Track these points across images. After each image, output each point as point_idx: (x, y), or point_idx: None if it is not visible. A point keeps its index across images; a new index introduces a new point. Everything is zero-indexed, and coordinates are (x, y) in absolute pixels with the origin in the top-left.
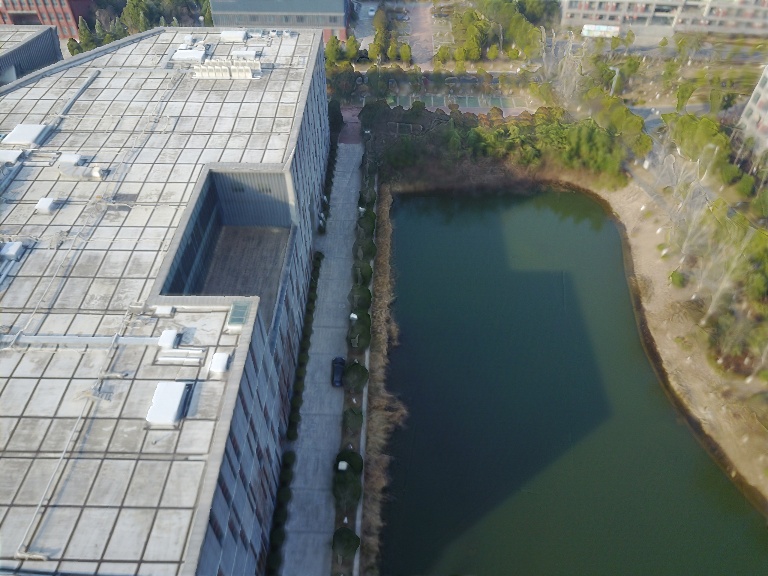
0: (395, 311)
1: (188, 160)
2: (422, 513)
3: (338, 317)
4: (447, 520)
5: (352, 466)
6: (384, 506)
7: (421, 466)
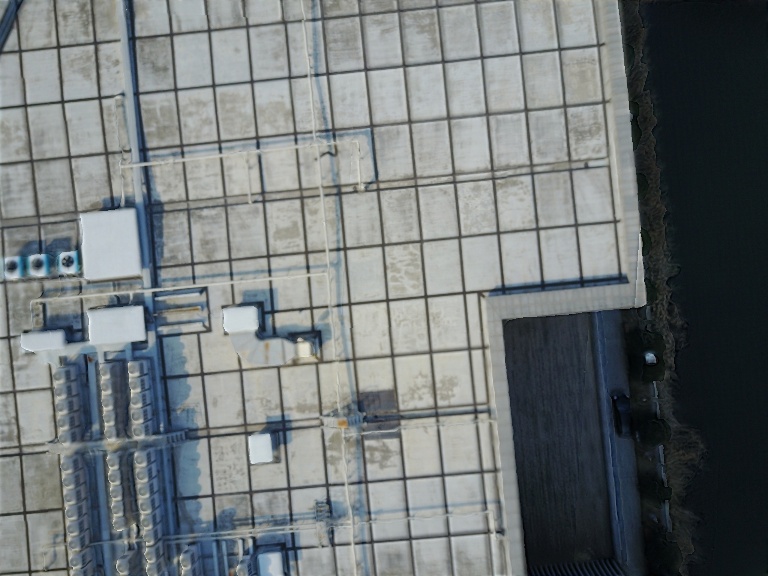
0: (674, 285)
1: (446, 282)
2: (733, 571)
3: (605, 321)
4: (760, 575)
5: (678, 573)
6: (692, 567)
7: (730, 520)
